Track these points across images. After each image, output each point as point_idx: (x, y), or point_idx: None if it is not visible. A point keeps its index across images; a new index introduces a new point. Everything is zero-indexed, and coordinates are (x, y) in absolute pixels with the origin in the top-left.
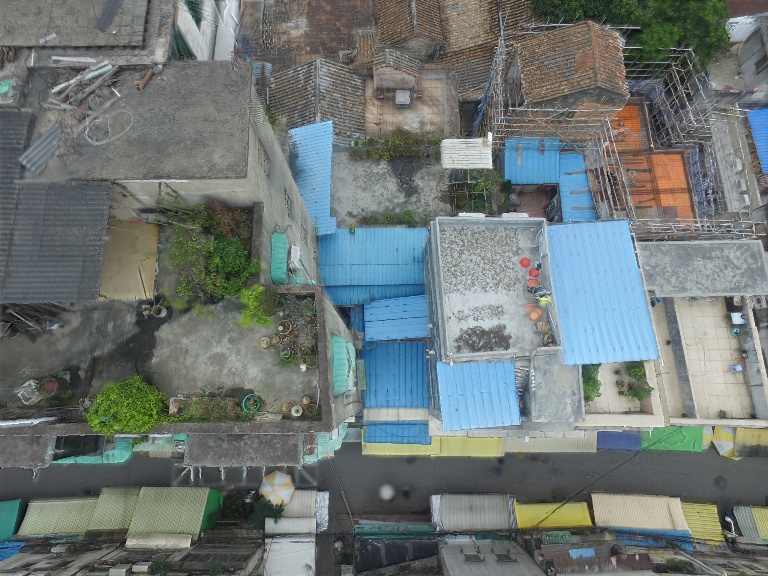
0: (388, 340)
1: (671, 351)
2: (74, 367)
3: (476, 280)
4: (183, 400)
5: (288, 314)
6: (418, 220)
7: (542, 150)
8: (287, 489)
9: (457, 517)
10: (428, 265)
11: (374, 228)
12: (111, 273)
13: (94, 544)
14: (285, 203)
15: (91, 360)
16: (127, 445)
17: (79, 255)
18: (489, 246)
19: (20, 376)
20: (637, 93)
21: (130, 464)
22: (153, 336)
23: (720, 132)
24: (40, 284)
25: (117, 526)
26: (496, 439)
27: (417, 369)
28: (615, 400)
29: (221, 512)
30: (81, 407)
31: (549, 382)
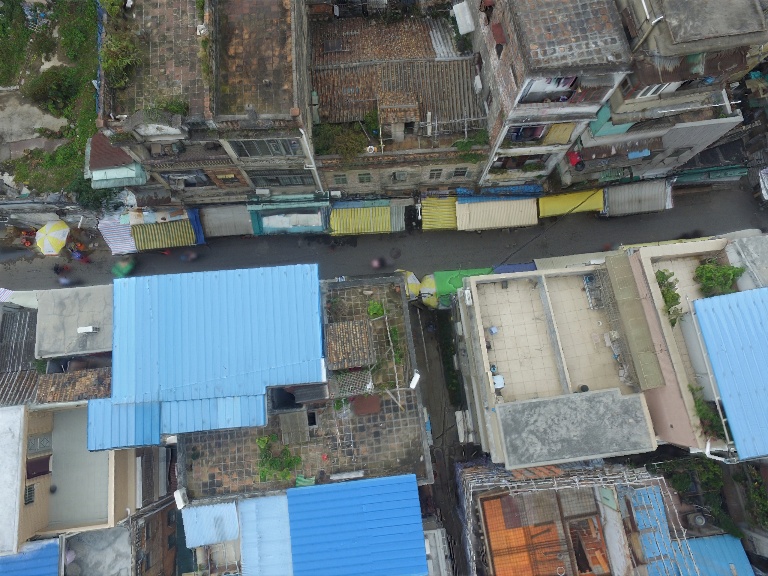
0: None
1: None
2: None
3: None
4: None
5: None
6: None
7: None
8: None
9: (652, 192)
10: None
11: None
12: None
13: None
14: None
15: None
16: None
17: None
18: None
19: None
20: None
21: None
22: None
23: None
24: None
25: None
26: None
27: None
28: None
29: None
30: None
31: None
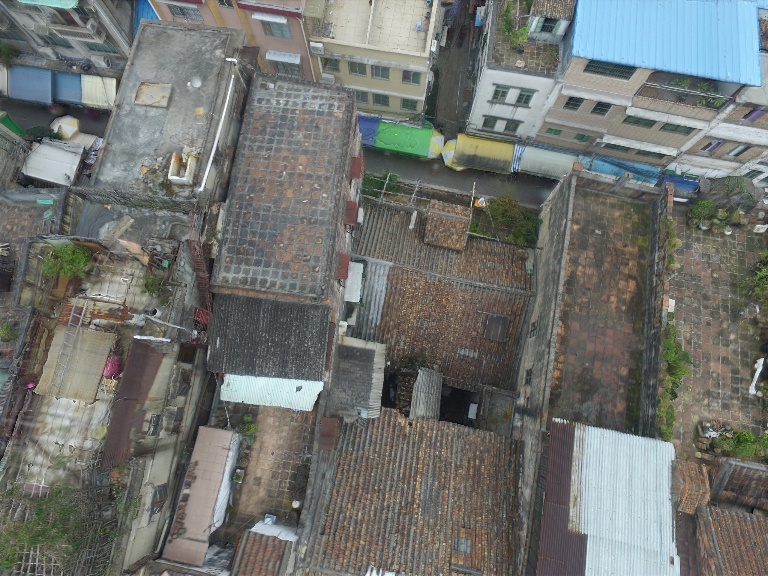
0: None
1: None
2: None
3: None
4: None
5: None
6: None
7: None
8: (70, 125)
9: None
10: None
11: None
12: None
13: None
14: None
15: None
16: None
17: None
18: None
19: None
20: None
21: None
22: None
23: None
24: None
25: None
26: None
27: None
28: None
29: None
30: None
31: None
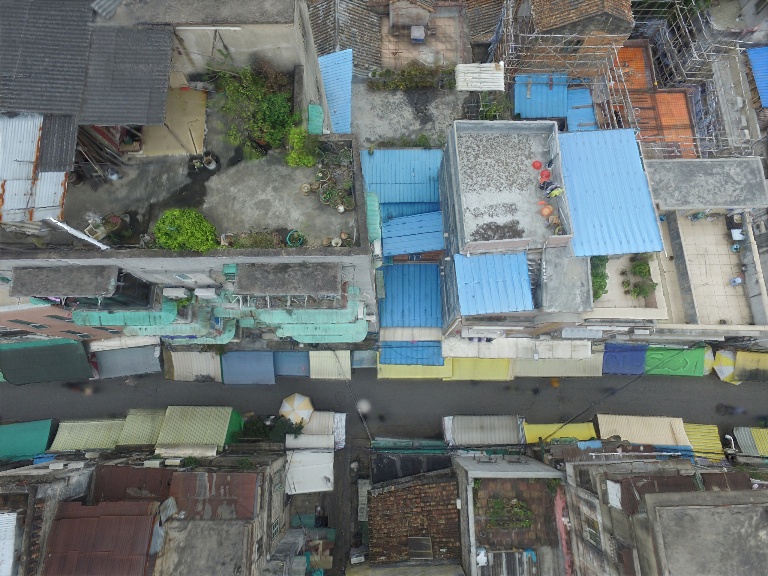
0: (404, 260)
1: (674, 266)
2: (133, 212)
3: (491, 181)
4: (233, 236)
5: (327, 164)
6: (433, 145)
7: (550, 85)
8: (306, 409)
9: (469, 436)
10: (444, 177)
11: (392, 150)
12: (164, 132)
13: (125, 453)
14: (317, 90)
15: (148, 206)
16: (172, 308)
17: (146, 87)
18: (503, 150)
19: (84, 219)
20: (642, 36)
21: (154, 392)
22: (204, 186)
23: (721, 72)
24: (113, 110)
25: (145, 442)
26: (506, 363)
27: (431, 290)
28: (621, 299)
29: (243, 432)
30: (142, 241)
31: (559, 274)
